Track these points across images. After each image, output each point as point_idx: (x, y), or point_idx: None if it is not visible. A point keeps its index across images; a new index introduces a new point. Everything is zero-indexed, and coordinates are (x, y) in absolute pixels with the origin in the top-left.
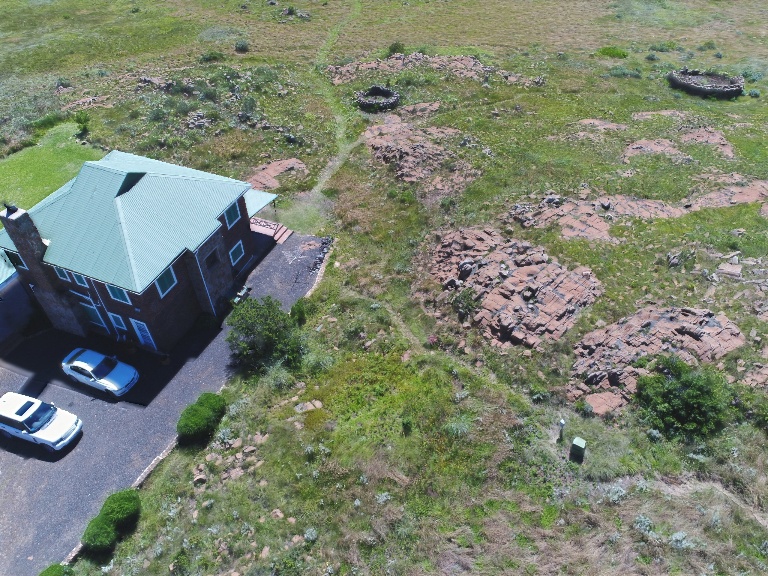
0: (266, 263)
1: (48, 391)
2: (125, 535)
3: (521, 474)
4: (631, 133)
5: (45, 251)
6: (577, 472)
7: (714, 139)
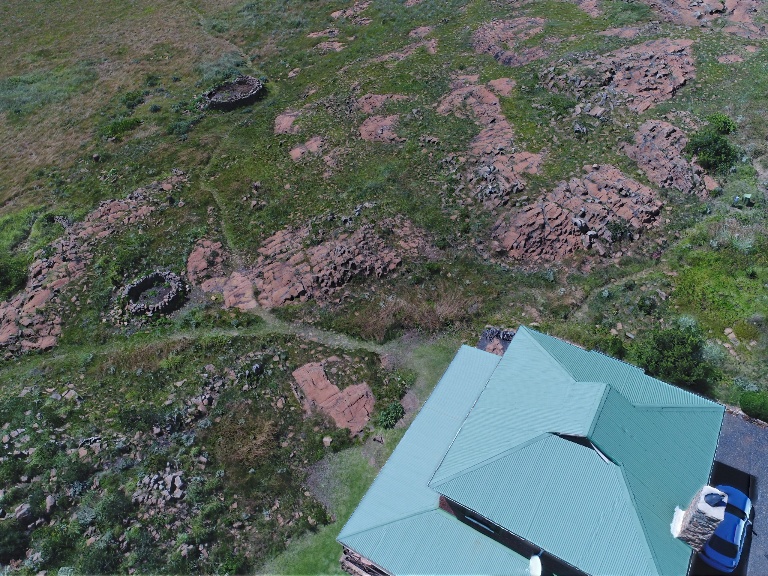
0: None
1: None
2: None
3: None
4: (338, 135)
5: None
6: (762, 204)
7: (381, 98)
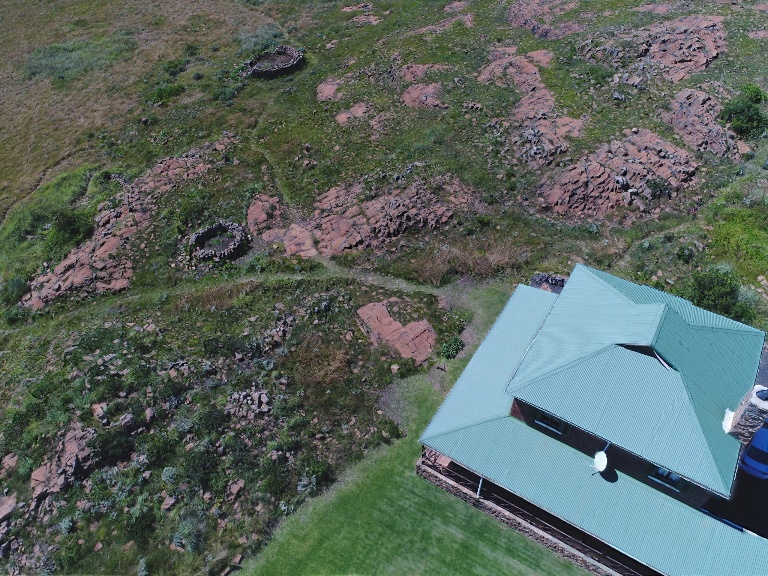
0: None
1: None
2: None
3: None
4: (382, 102)
5: None
6: None
7: (423, 68)
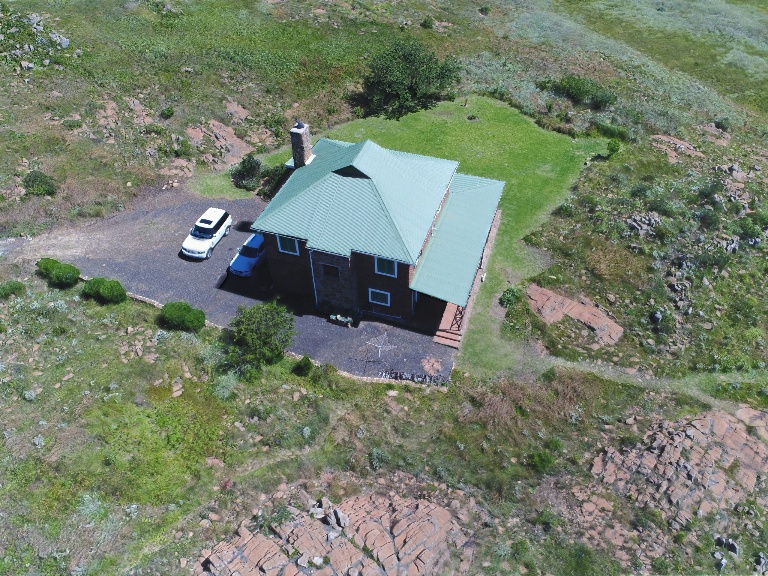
0: (398, 332)
1: (246, 235)
2: (98, 301)
3: (18, 567)
4: None
5: (302, 166)
6: None
7: None
